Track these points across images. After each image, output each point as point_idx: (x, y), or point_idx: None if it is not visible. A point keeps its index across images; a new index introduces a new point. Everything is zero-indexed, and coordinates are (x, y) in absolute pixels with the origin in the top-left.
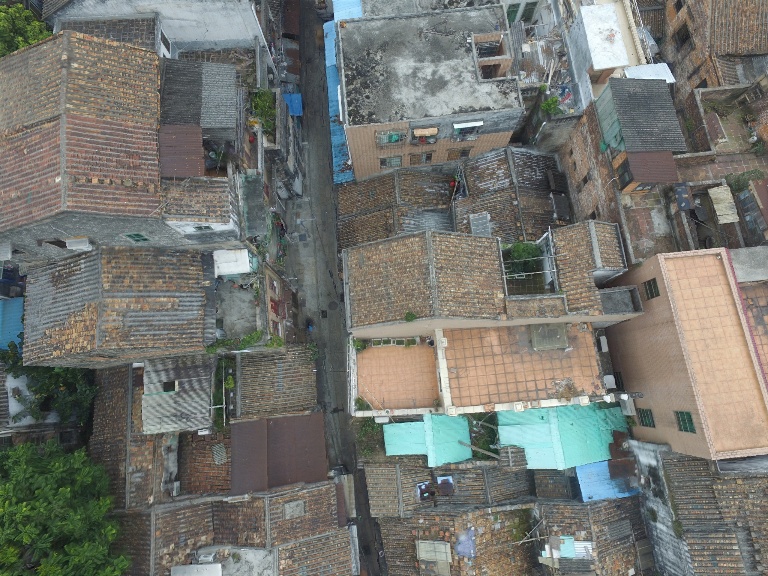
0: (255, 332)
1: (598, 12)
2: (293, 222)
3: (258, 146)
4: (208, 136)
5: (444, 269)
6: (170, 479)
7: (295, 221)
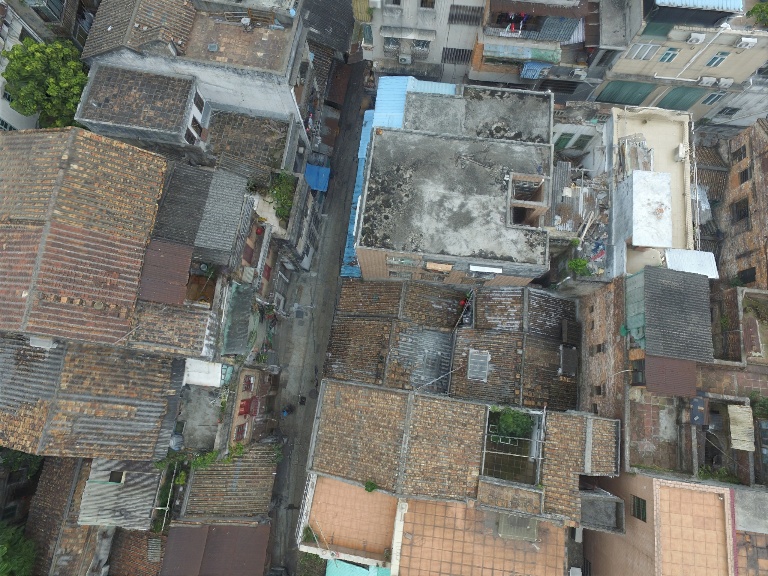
0: (210, 454)
1: (651, 180)
2: (294, 296)
3: (263, 243)
4: (200, 256)
5: (419, 438)
6: (98, 566)
7: (296, 295)
